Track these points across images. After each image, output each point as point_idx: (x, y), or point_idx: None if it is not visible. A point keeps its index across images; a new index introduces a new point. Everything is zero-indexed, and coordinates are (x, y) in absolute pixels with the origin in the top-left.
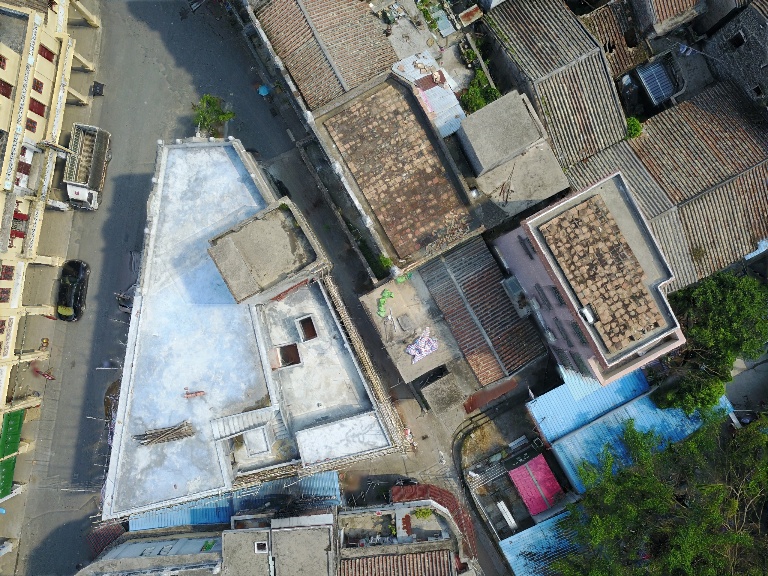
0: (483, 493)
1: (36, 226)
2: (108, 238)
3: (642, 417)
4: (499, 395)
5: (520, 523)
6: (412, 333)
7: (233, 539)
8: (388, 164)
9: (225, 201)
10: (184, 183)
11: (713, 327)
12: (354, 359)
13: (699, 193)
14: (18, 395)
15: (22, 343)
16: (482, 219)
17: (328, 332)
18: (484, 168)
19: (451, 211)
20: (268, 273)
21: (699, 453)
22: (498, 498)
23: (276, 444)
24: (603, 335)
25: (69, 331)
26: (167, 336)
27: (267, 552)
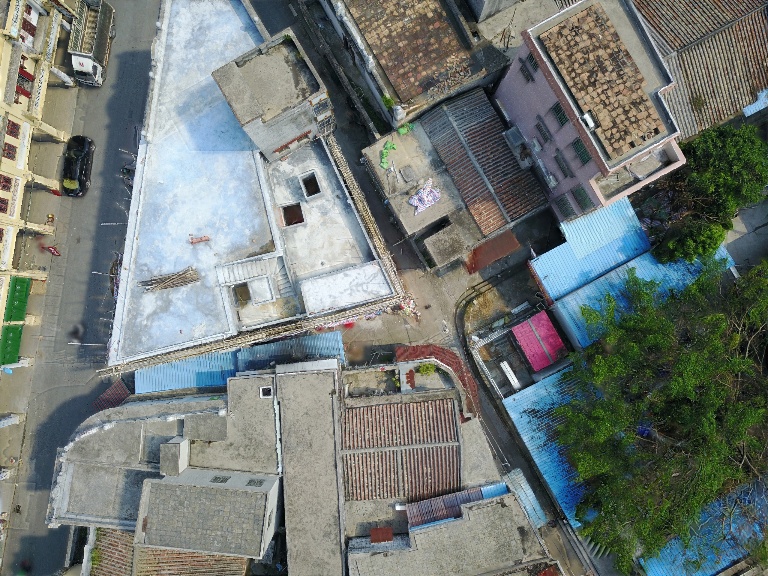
0: (486, 359)
1: (41, 86)
2: (112, 115)
3: (644, 272)
4: (501, 256)
5: (523, 388)
6: (414, 184)
7: (238, 385)
8: (390, 9)
9: (228, 49)
10: (188, 32)
11: (713, 173)
12: (357, 214)
13: (698, 39)
14: (24, 262)
15: (28, 208)
16: (483, 63)
17: (331, 191)
18: (485, 3)
19: (452, 55)
20: (272, 107)
21: (701, 295)
22: (501, 361)
23: (280, 302)
24: (604, 141)
25: (74, 207)
26: (172, 183)
27: (272, 397)
